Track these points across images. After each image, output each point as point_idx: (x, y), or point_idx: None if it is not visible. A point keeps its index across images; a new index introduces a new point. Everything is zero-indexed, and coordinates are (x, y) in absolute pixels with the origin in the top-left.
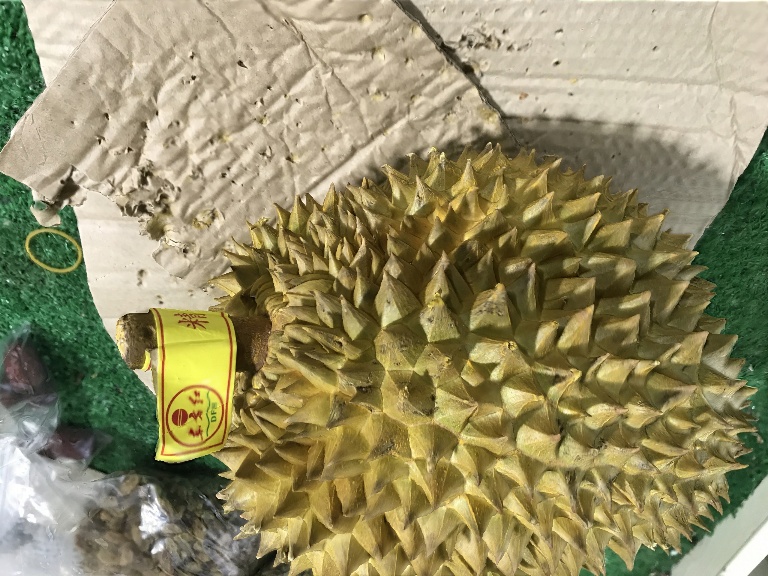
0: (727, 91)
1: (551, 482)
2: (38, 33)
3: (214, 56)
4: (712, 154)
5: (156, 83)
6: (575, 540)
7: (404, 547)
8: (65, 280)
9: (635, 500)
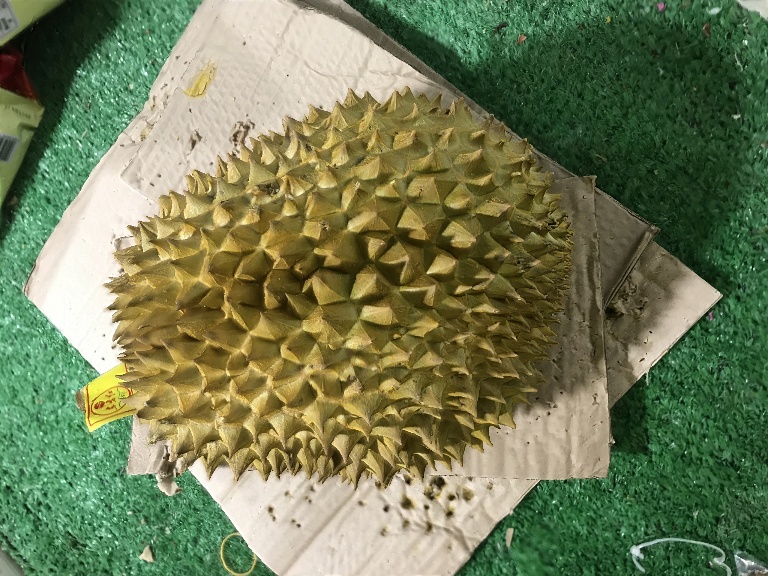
0: (366, 74)
1: (218, 215)
2: None
3: None
4: None
5: None
6: None
7: None
8: None
9: None
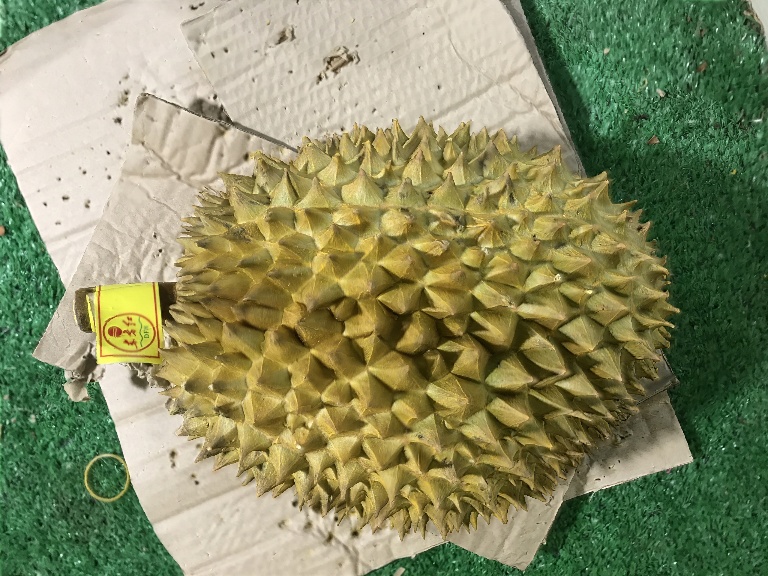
0: (504, 84)
1: (390, 221)
2: (67, 281)
3: (169, 231)
4: (530, 126)
5: (137, 264)
6: (451, 272)
7: (295, 325)
8: (121, 509)
9: (485, 222)
